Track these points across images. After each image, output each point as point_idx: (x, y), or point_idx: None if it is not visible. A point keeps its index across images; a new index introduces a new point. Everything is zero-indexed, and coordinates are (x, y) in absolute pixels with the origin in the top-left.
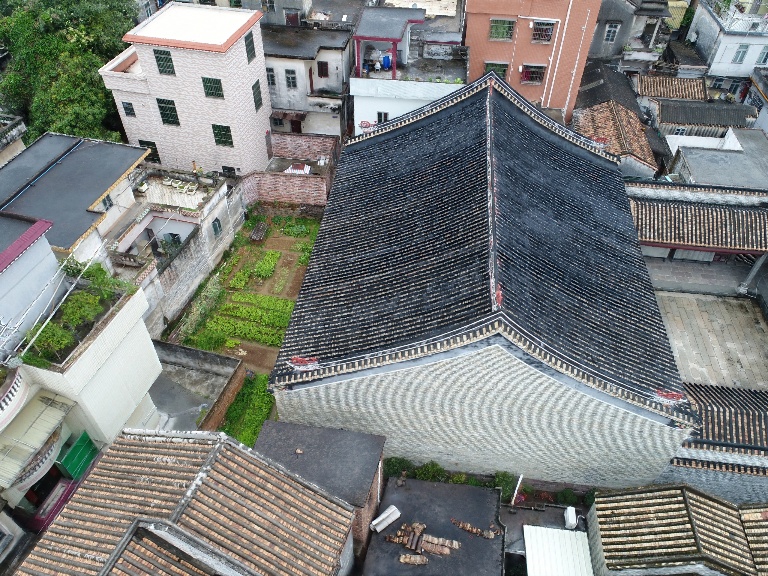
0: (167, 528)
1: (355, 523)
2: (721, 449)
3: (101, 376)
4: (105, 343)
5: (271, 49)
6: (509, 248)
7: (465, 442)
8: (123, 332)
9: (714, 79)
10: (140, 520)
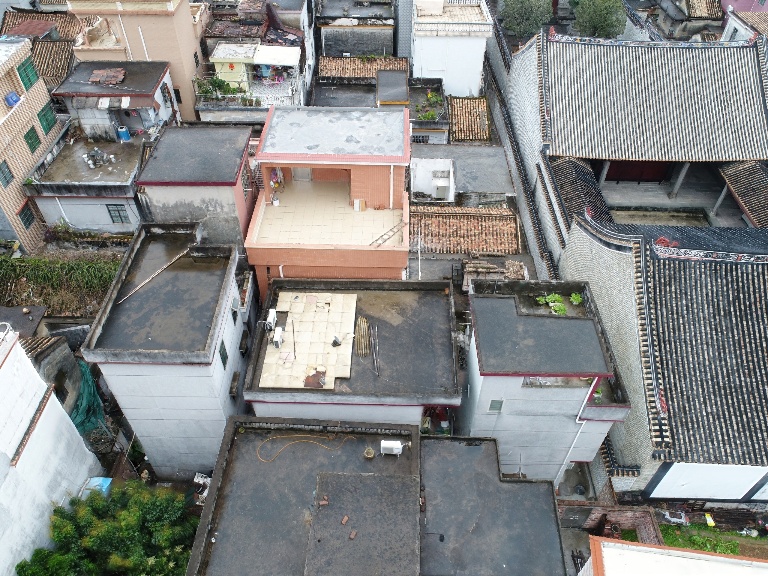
0: None
1: None
2: None
3: None
4: None
5: (541, 571)
6: None
7: None
8: None
9: None
10: None
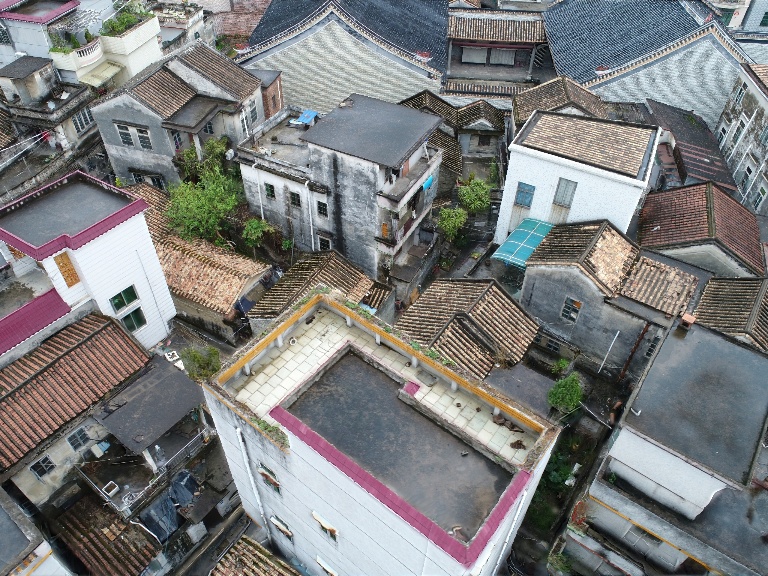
0: (176, 59)
1: (266, 108)
2: (459, 94)
3: (137, 57)
4: (140, 35)
5: None
6: (353, 1)
7: (332, 106)
8: (148, 36)
9: None
10: (164, 63)
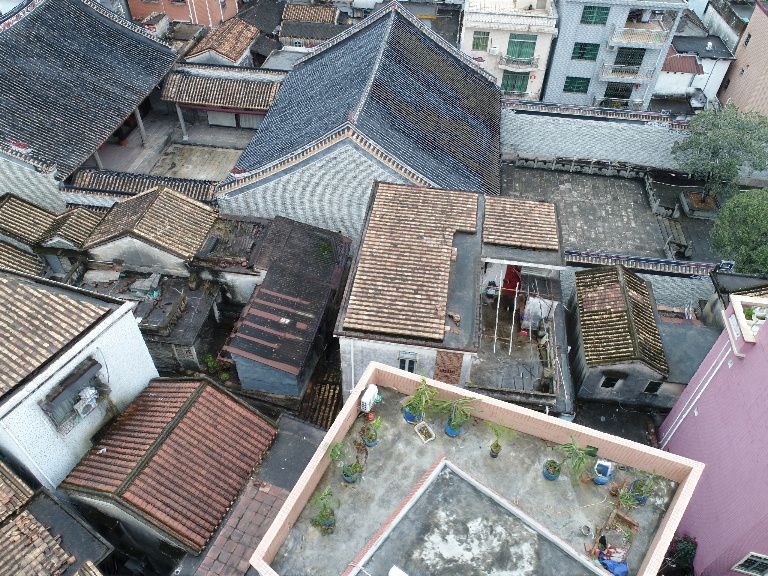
0: None
1: None
2: (82, 192)
3: None
4: None
5: None
6: None
7: None
8: None
9: (363, 11)
10: None
